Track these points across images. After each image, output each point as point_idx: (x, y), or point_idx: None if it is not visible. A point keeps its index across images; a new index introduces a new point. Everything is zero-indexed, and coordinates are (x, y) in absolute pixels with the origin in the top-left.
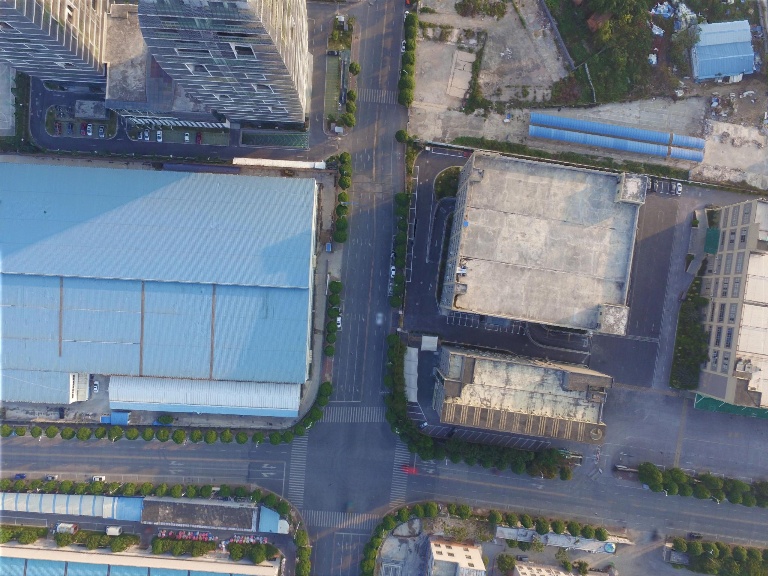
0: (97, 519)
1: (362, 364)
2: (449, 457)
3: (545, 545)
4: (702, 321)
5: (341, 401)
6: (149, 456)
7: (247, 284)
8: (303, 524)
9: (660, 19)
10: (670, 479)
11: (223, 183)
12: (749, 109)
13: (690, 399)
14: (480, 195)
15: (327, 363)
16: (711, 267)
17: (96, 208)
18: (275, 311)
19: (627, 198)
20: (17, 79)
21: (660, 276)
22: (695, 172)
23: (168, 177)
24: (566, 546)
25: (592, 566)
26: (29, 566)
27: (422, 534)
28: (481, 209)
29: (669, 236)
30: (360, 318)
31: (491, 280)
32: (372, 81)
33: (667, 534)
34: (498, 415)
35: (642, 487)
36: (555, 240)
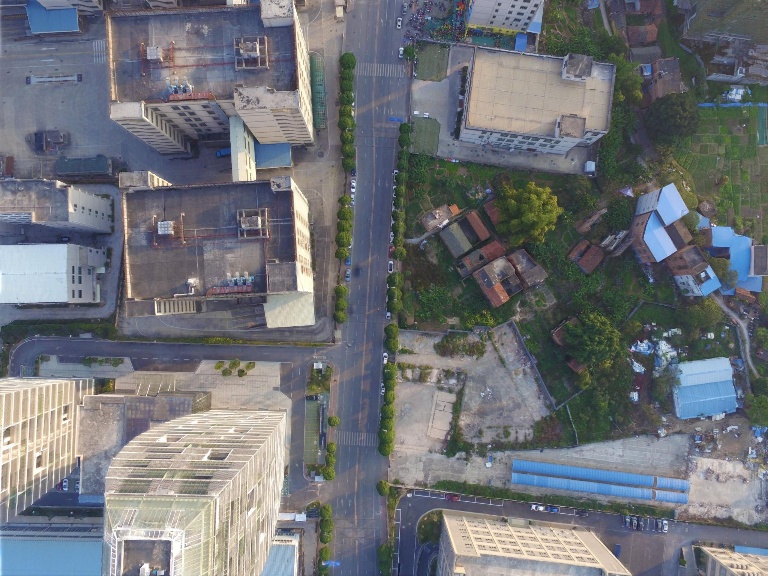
0: None
1: None
2: None
3: None
4: None
5: None
6: None
7: None
8: None
9: (640, 357)
10: None
11: None
12: (733, 443)
13: None
14: None
15: None
16: None
17: None
18: None
19: None
20: None
21: None
22: (681, 510)
23: None
24: None
25: None
26: None
27: None
28: None
29: (656, 574)
30: None
31: None
32: (352, 424)
33: None
34: None
35: None
36: None
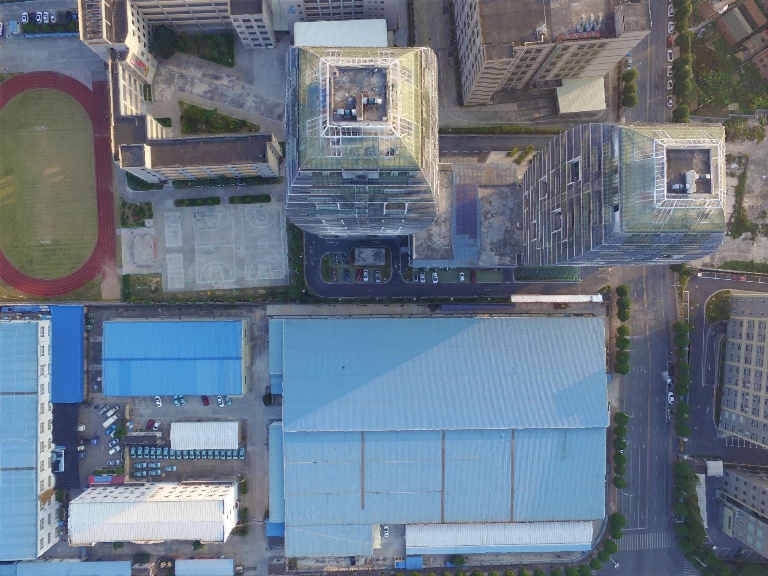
0: None
1: (645, 491)
2: None
3: None
4: None
5: (627, 529)
6: None
7: (548, 427)
8: None
9: None
10: None
11: (514, 327)
12: None
13: None
14: None
15: (611, 492)
16: None
17: (393, 360)
18: (573, 451)
19: None
20: (288, 228)
21: None
22: None
23: (460, 324)
24: None
25: None
26: None
27: None
28: None
29: None
30: (641, 445)
31: None
32: None
33: None
34: None
35: None
36: None
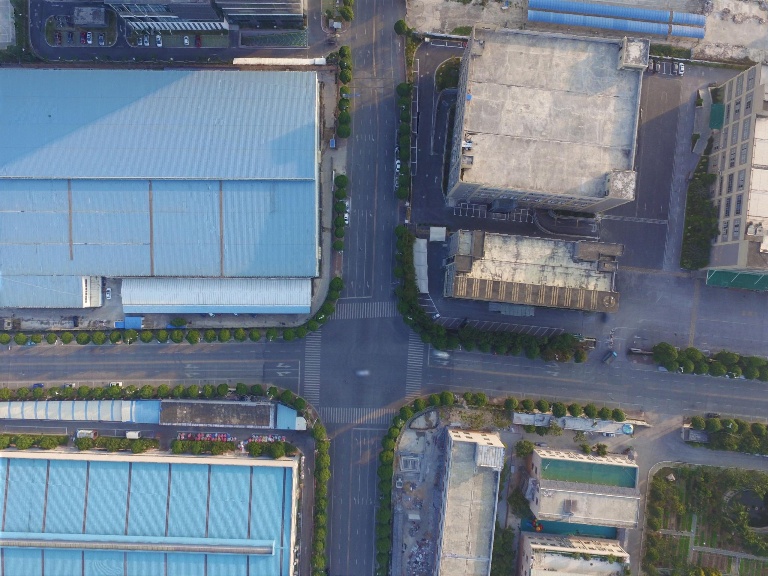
0: (116, 425)
1: (371, 260)
2: (463, 345)
3: (563, 429)
4: (710, 198)
5: (352, 297)
6: (164, 360)
7: (253, 178)
8: (320, 421)
9: None
10: (685, 356)
11: (225, 79)
12: None
13: (702, 279)
14: (482, 69)
15: (336, 260)
16: (717, 143)
17: (100, 110)
18: (282, 205)
19: (630, 62)
20: None
21: (666, 158)
22: (697, 51)
23: (170, 76)
24: (584, 429)
25: (611, 450)
26: (51, 467)
27: (439, 426)
28: (484, 83)
29: (673, 117)
30: (367, 214)
31: (497, 153)
32: None
33: (685, 416)
34: (510, 287)
35: (657, 370)
36: (559, 110)
